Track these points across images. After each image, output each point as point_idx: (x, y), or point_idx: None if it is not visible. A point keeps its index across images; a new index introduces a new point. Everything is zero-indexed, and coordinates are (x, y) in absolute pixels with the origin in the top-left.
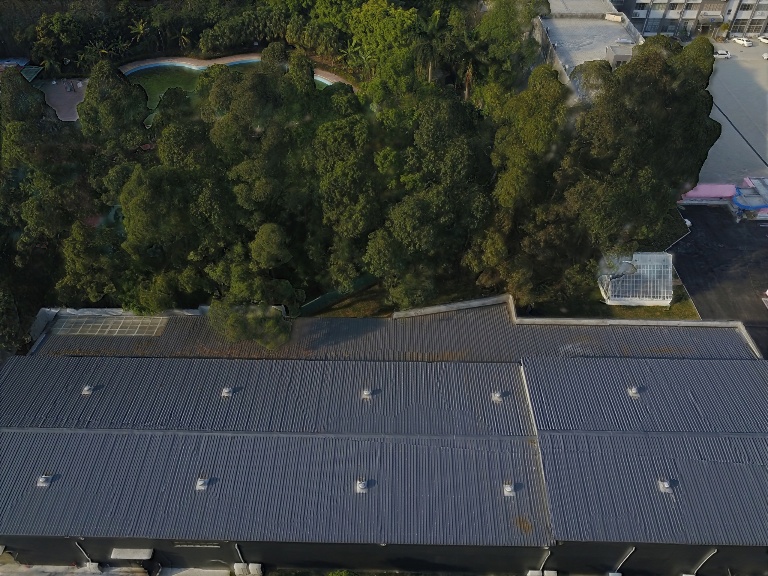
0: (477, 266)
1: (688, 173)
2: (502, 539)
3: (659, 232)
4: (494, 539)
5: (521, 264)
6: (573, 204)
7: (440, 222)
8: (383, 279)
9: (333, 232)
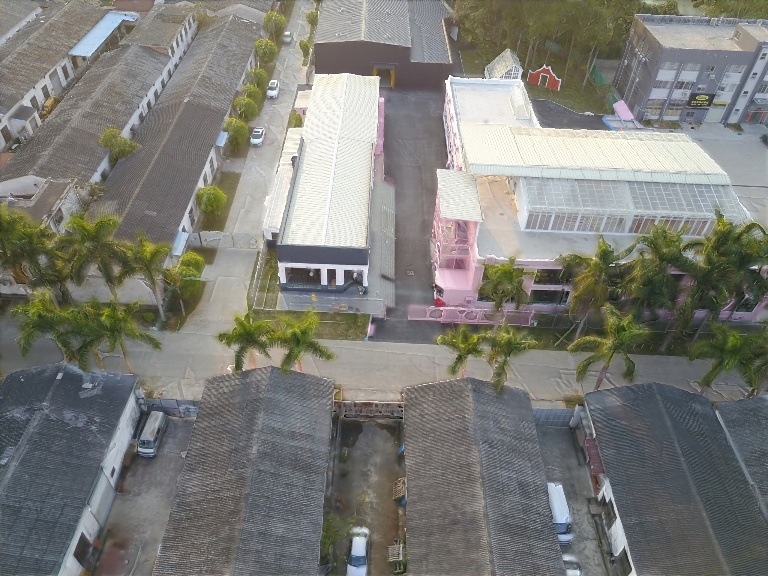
0: None
1: None
2: None
3: None
4: None
5: None
6: None
7: None
8: None
9: None
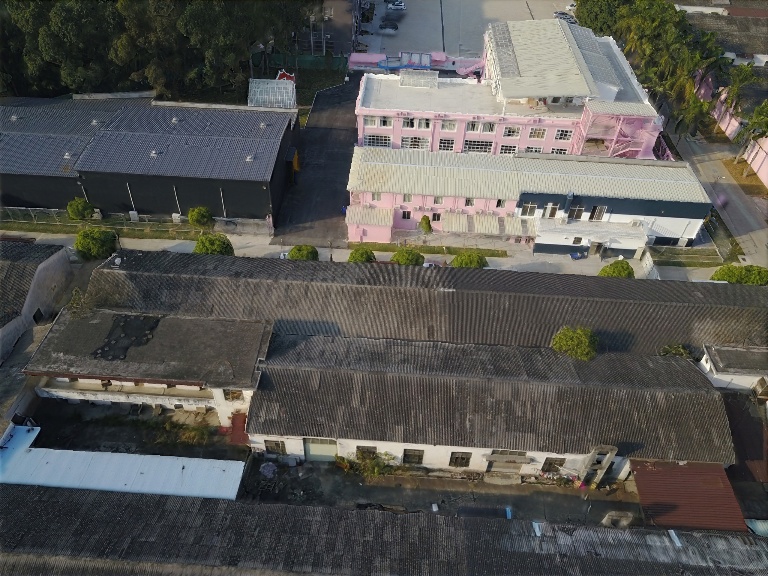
0: (116, 58)
1: (269, 10)
2: (48, 173)
3: (235, 41)
4: (44, 173)
5: (153, 63)
6: (151, 7)
7: (82, 22)
8: (60, 68)
9: (25, 33)
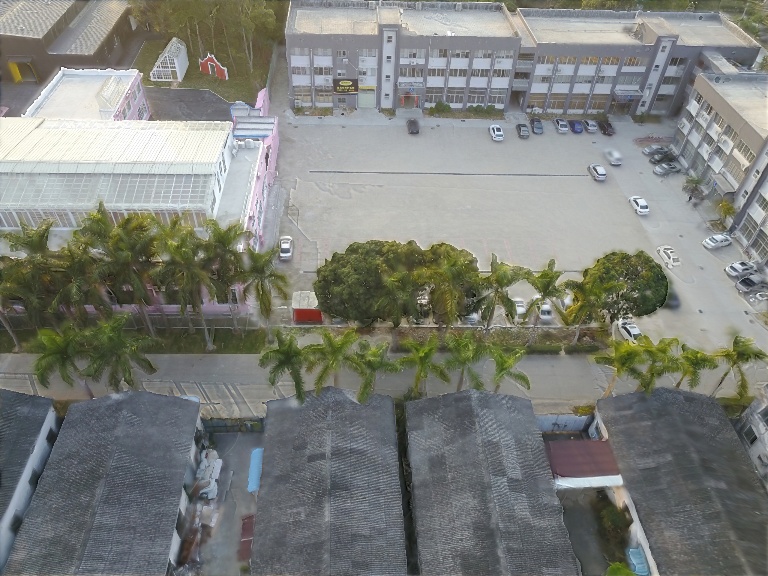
0: None
1: None
2: None
3: None
4: None
5: None
6: None
7: None
8: None
9: None
